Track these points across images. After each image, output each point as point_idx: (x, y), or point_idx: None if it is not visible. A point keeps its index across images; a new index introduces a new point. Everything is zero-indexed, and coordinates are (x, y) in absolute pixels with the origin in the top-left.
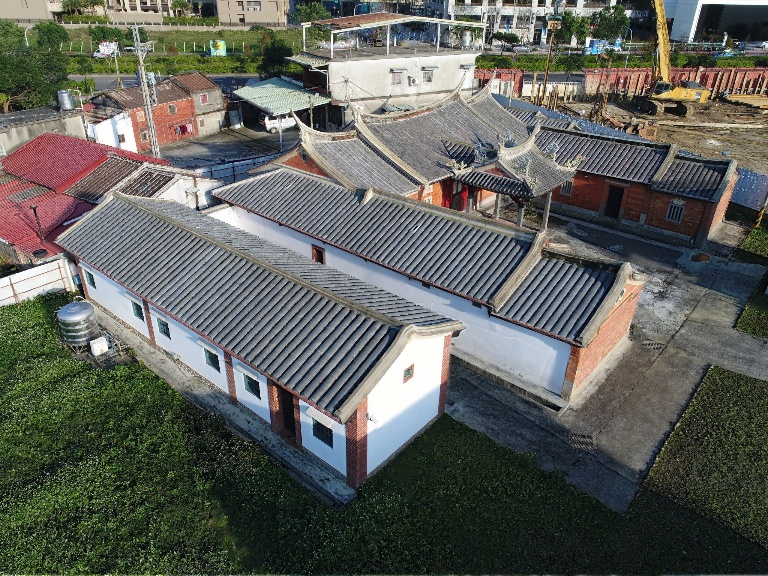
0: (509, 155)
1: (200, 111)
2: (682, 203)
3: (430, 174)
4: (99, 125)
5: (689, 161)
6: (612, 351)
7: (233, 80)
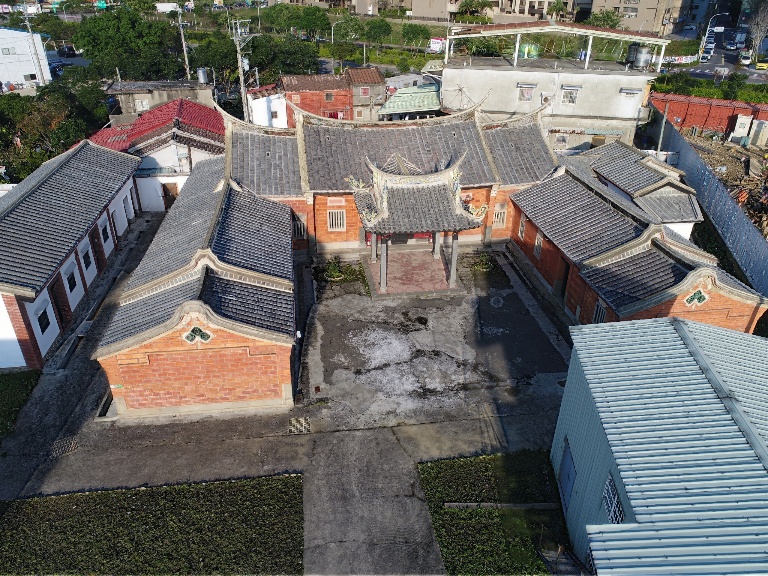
0: (395, 182)
1: (359, 102)
2: (605, 305)
3: (322, 184)
4: (255, 101)
5: (664, 253)
6: (241, 405)
7: (425, 80)
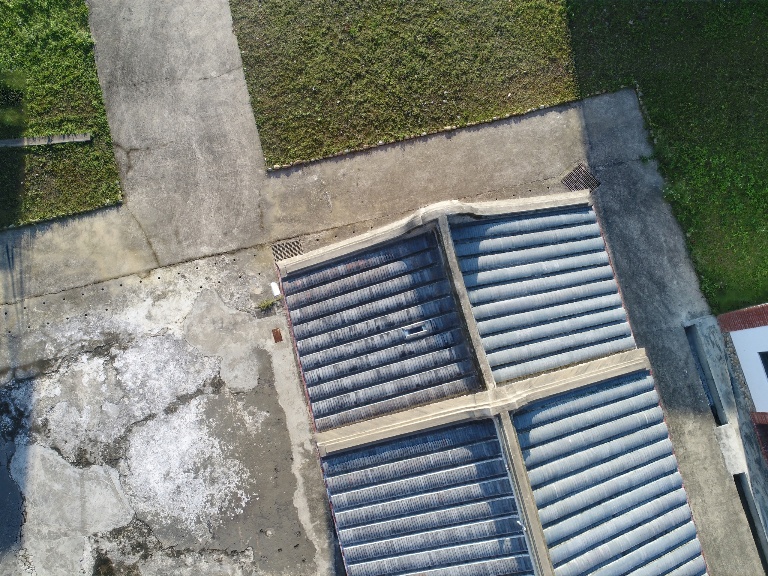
0: None
1: None
2: None
3: None
4: None
5: None
6: None
7: None
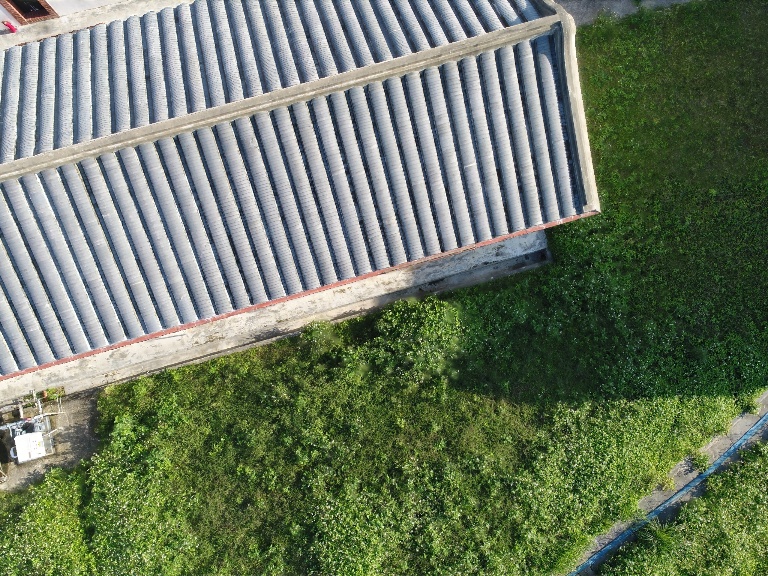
0: None
1: None
2: None
3: None
4: None
5: None
6: None
7: None
